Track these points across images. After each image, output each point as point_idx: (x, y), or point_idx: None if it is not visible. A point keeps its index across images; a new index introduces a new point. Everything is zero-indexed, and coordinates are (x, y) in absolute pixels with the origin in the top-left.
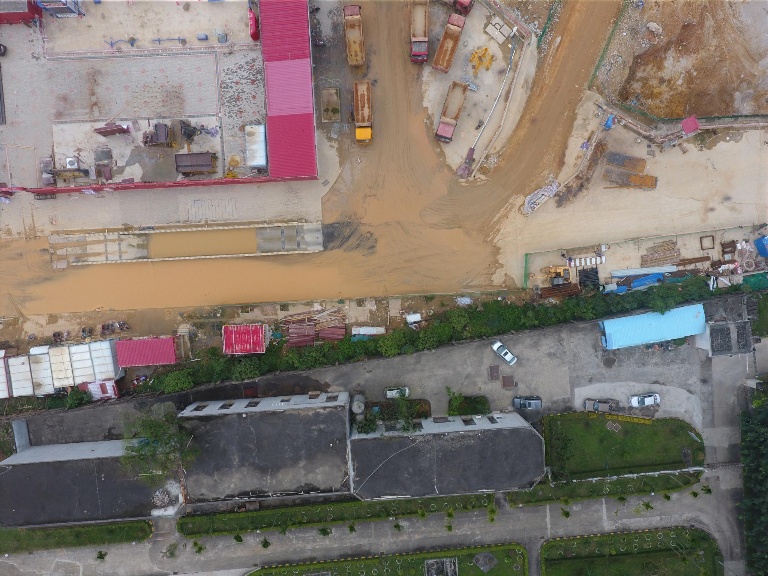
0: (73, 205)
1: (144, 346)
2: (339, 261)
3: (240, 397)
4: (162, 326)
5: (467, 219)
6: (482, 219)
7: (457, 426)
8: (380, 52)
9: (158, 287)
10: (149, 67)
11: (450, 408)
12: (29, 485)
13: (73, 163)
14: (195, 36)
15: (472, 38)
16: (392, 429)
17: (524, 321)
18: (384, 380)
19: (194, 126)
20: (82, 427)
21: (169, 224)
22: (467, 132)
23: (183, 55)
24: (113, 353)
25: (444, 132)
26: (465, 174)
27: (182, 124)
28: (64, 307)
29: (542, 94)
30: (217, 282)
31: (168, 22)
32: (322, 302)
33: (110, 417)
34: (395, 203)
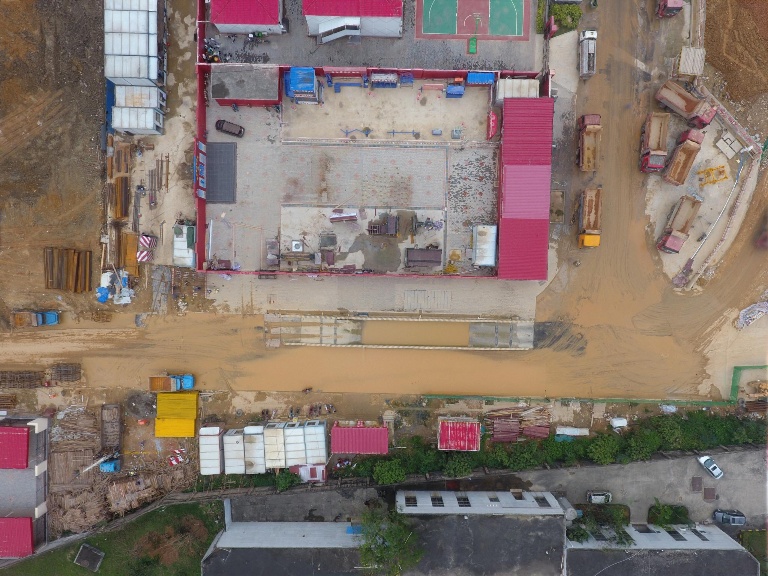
0: (292, 286)
1: (359, 434)
2: (548, 360)
3: (442, 489)
4: (367, 411)
5: (679, 328)
6: (694, 329)
7: (668, 541)
8: (608, 158)
9: (368, 373)
10: (381, 157)
11: (650, 516)
12: (246, 569)
13: (299, 247)
14: (429, 130)
15: (701, 151)
16: (601, 538)
17: (737, 438)
18: (586, 483)
19: (419, 218)
20: (284, 507)
21: (384, 311)
22: (688, 243)
23: (415, 148)
24: (325, 438)
25: (673, 245)
26: (681, 284)
27: (416, 219)
28: (273, 385)
29: (760, 208)
30: (425, 372)
31: (404, 115)
32: (527, 399)
33: (312, 499)
34: (608, 307)
